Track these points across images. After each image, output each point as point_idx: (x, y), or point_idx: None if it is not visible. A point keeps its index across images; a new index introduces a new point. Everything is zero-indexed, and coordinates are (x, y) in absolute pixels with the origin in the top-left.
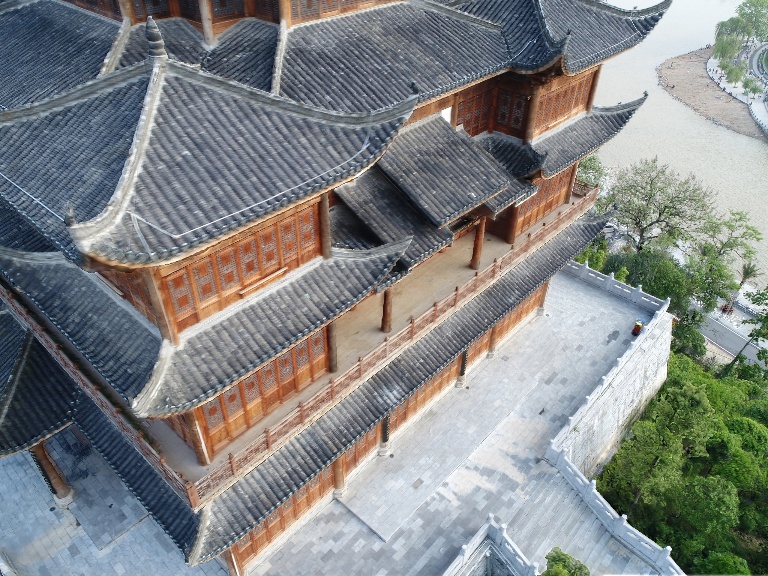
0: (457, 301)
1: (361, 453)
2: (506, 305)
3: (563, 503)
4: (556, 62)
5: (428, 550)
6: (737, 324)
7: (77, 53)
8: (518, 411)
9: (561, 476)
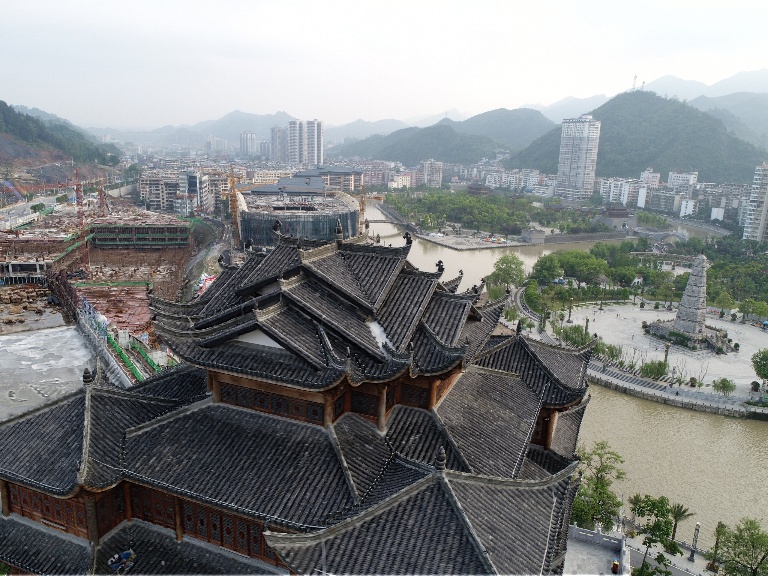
0: None
1: None
2: None
3: None
4: (577, 401)
5: None
6: (631, 536)
7: (297, 456)
8: None
9: None
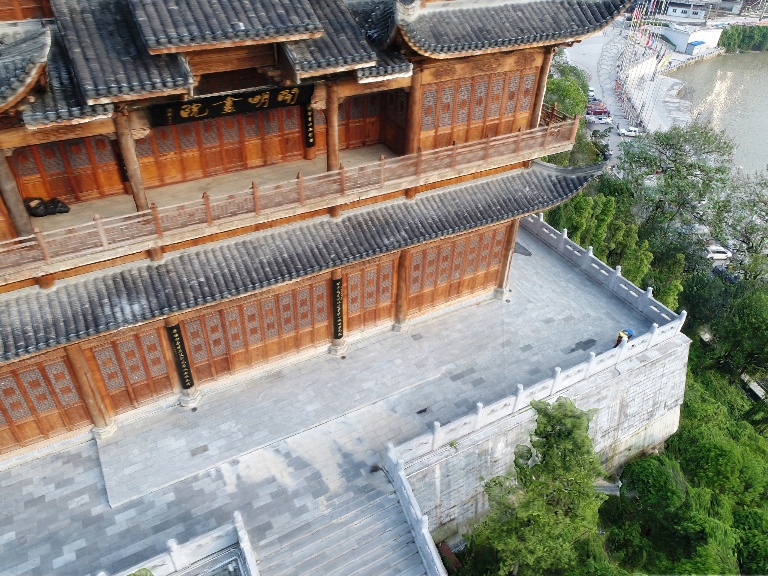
0: (262, 207)
1: (142, 392)
2: (376, 245)
3: (380, 536)
4: None
5: (154, 535)
6: None
7: None
8: (391, 402)
9: (395, 499)
